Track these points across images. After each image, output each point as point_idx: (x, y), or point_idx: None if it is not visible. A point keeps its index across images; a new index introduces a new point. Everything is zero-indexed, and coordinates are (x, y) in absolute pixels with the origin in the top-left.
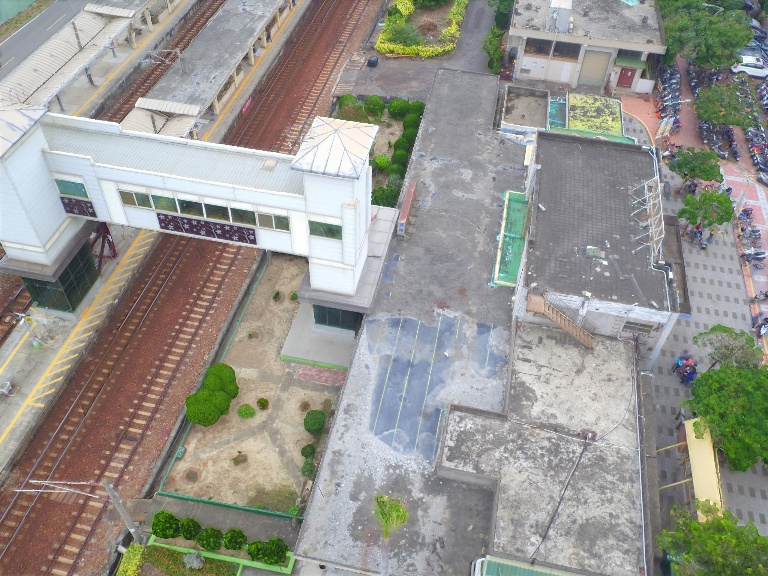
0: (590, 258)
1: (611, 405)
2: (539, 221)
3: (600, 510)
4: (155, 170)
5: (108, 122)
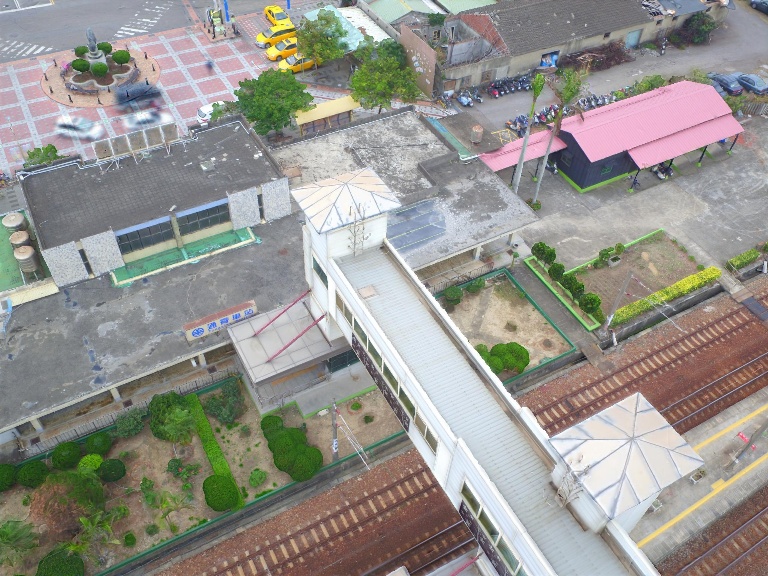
0: (215, 166)
1: (318, 149)
2: (192, 205)
3: (390, 134)
4: (466, 367)
5: (468, 451)
